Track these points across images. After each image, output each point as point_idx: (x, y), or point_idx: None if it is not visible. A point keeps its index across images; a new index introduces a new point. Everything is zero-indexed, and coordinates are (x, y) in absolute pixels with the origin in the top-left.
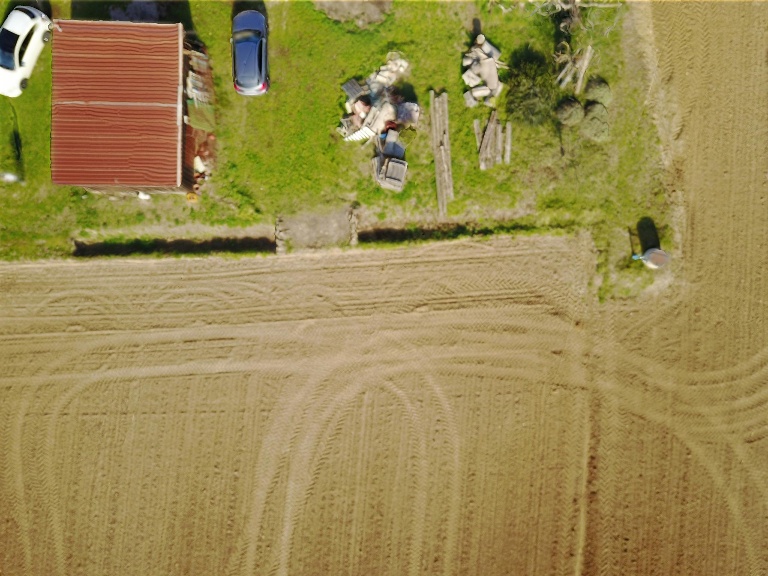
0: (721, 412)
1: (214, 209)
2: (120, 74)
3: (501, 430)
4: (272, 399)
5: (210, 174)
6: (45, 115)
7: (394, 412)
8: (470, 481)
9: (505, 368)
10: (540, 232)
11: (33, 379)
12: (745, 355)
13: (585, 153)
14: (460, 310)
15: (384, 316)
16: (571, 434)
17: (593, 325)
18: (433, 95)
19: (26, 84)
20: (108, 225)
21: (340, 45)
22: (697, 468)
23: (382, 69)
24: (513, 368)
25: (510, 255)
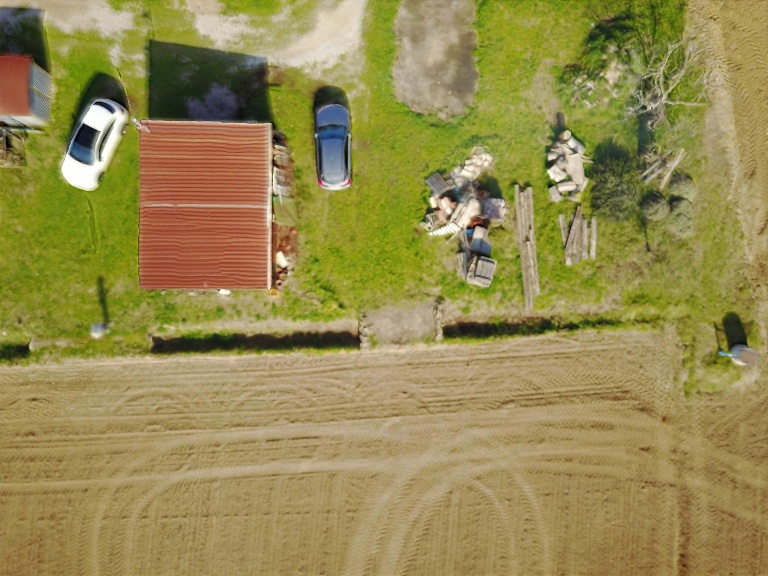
0: None
1: (296, 305)
2: (209, 175)
3: (590, 529)
4: (357, 499)
5: (292, 269)
6: (122, 209)
7: (482, 512)
8: None
9: (593, 465)
10: (625, 326)
11: (110, 481)
12: None
13: (671, 248)
14: (547, 406)
15: (470, 413)
16: (660, 532)
17: (679, 420)
18: (518, 189)
19: (103, 177)
20: (187, 321)
21: (424, 138)
22: None
23: (467, 163)
24: (601, 465)
25: (595, 350)
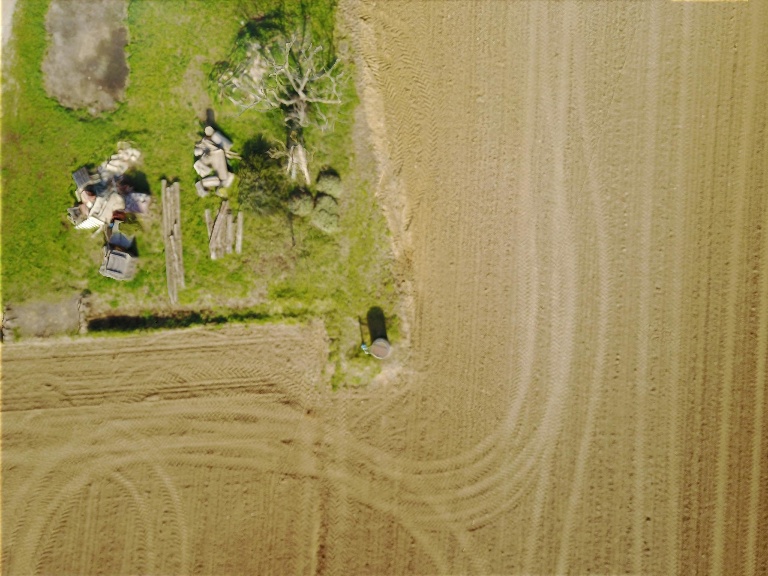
0: (445, 500)
1: None
2: None
3: (229, 520)
4: None
5: None
6: None
7: (120, 504)
8: (196, 573)
9: (234, 458)
10: (273, 321)
11: None
12: (468, 444)
13: (315, 243)
14: (191, 399)
15: (113, 406)
16: (299, 524)
17: (325, 413)
18: (165, 184)
19: None
20: None
21: (72, 133)
22: (422, 556)
23: (113, 158)
24: (242, 458)
25: (243, 343)
